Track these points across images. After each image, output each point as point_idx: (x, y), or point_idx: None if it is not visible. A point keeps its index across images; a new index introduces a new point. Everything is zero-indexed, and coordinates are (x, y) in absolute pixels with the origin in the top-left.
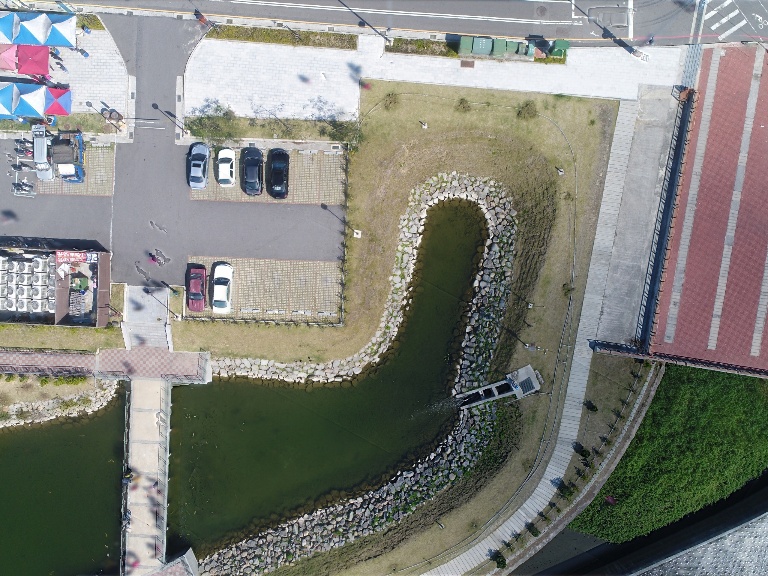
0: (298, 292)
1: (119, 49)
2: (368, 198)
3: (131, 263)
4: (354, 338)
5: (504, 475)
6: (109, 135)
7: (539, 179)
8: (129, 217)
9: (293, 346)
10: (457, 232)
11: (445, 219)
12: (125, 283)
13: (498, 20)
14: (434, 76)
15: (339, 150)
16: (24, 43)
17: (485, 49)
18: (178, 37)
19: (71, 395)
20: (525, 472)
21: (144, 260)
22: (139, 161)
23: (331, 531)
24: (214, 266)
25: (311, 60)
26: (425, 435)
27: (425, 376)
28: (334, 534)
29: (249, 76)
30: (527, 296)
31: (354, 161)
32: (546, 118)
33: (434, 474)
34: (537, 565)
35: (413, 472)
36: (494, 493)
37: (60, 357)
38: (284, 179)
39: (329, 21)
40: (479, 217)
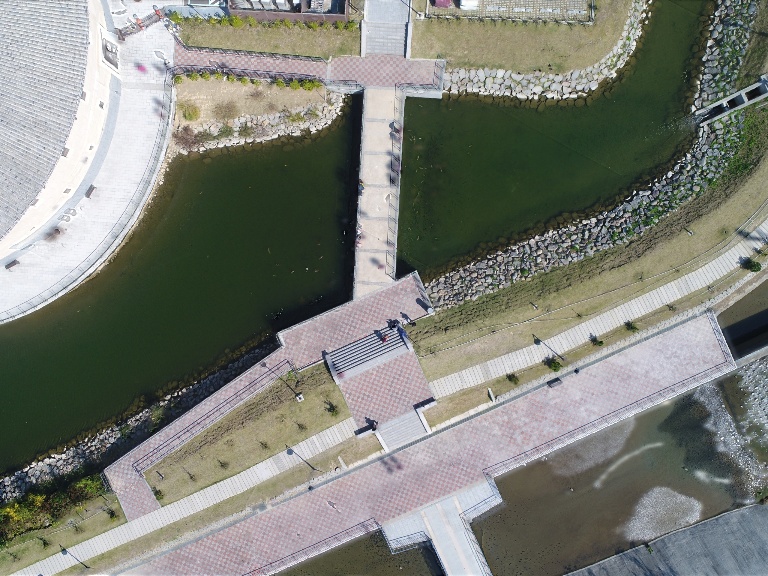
0: None
1: None
2: None
3: None
4: (599, 43)
5: (756, 180)
6: None
7: None
8: None
9: (536, 51)
10: None
11: None
12: None
13: None
14: None
15: None
16: None
17: None
18: None
19: (299, 107)
20: None
21: None
22: None
23: (567, 248)
24: None
25: None
26: (660, 156)
27: (660, 96)
28: (571, 250)
29: None
30: None
31: None
32: None
33: (675, 189)
34: (764, 301)
35: (650, 191)
36: (746, 198)
37: (292, 64)
38: None
39: None
40: None
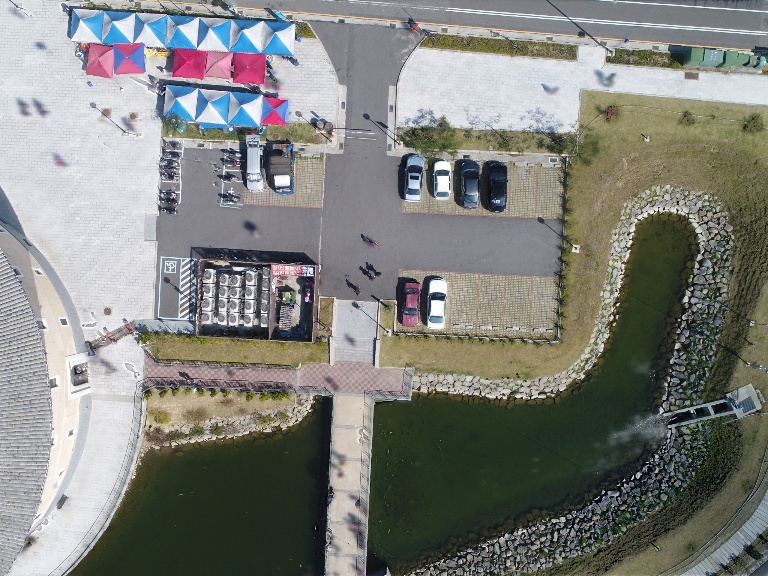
0: (513, 308)
1: (330, 58)
2: (587, 212)
3: (340, 277)
4: (566, 355)
5: (723, 496)
6: (318, 145)
7: (761, 194)
8: (339, 229)
9: (503, 362)
10: (665, 247)
11: (652, 233)
12: (334, 297)
13: (723, 31)
14: (657, 88)
15: (557, 163)
16: (241, 51)
17: (716, 61)
18: (391, 46)
19: (269, 410)
20: (745, 493)
21: (354, 274)
22: (349, 172)
23: (536, 551)
24: (426, 280)
25: (529, 71)
26: (629, 454)
27: (629, 393)
28: (540, 555)
29: (465, 86)
30: (748, 313)
31: (573, 174)
32: None
33: (643, 494)
34: None
35: (618, 492)
36: (712, 515)
37: (262, 372)
38: (504, 192)
39: (548, 31)
40: (688, 232)
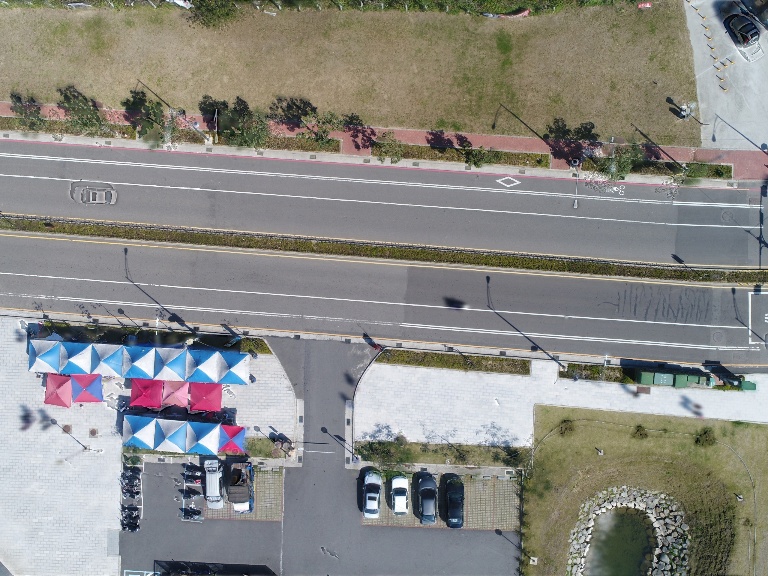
0: None
1: (286, 373)
2: (544, 524)
3: None
4: None
5: None
6: (277, 459)
7: (715, 501)
8: (299, 542)
9: None
10: (624, 538)
11: (611, 525)
12: None
13: (674, 346)
14: (610, 403)
15: (513, 475)
16: (197, 381)
17: (666, 384)
18: (347, 361)
19: None
20: None
21: None
22: (309, 486)
23: None
24: None
25: (484, 386)
26: None
27: None
28: None
29: (420, 401)
30: None
31: (529, 488)
32: (725, 445)
33: None
34: None
35: None
36: None
37: None
38: (461, 511)
39: (501, 345)
40: (646, 524)
